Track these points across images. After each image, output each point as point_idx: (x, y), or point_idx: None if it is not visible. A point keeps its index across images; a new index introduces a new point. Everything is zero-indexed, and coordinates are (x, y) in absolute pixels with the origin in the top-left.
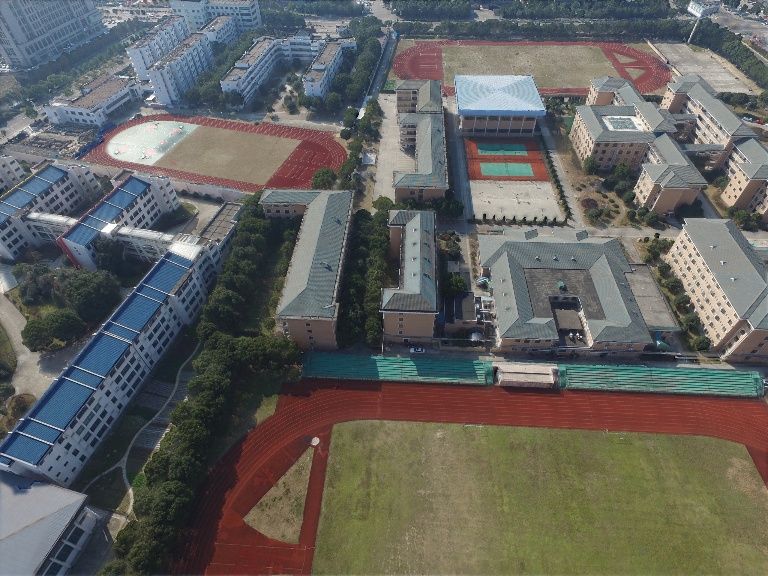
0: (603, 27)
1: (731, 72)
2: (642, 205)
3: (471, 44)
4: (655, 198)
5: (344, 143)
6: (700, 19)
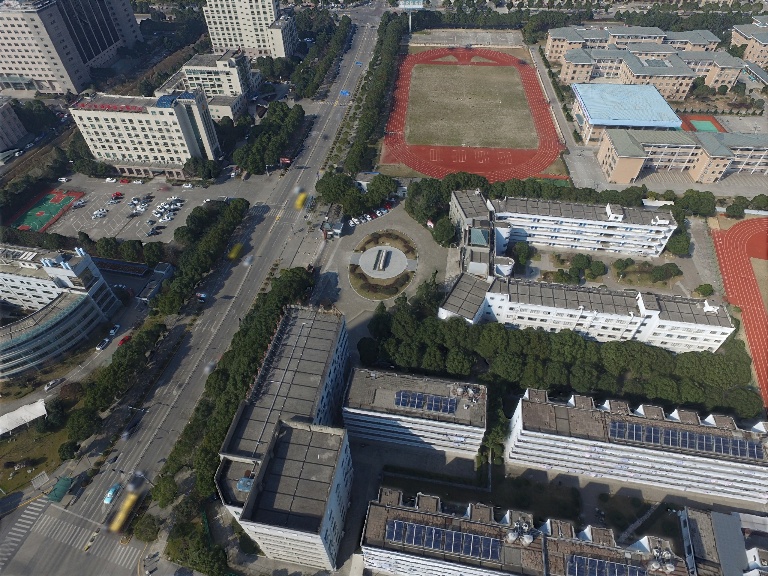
0: (395, 49)
1: (475, 32)
2: (730, 87)
3: (401, 124)
4: (736, 77)
5: (732, 221)
6: (387, 14)
